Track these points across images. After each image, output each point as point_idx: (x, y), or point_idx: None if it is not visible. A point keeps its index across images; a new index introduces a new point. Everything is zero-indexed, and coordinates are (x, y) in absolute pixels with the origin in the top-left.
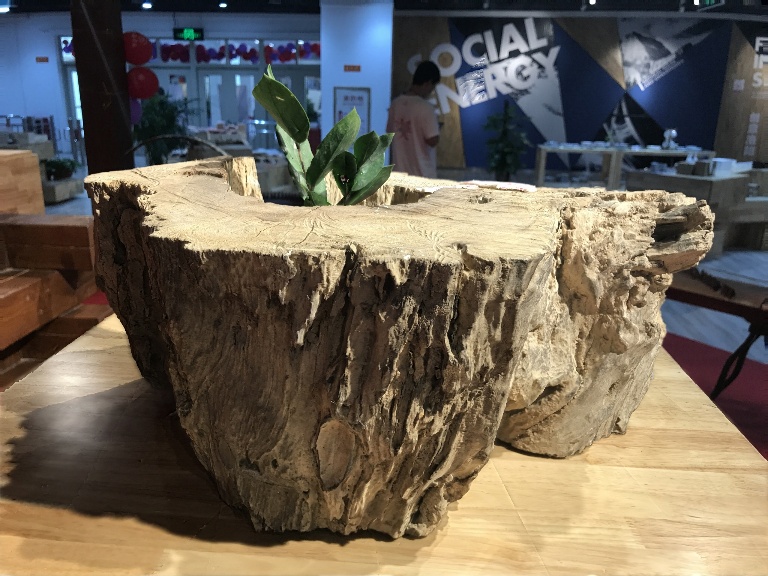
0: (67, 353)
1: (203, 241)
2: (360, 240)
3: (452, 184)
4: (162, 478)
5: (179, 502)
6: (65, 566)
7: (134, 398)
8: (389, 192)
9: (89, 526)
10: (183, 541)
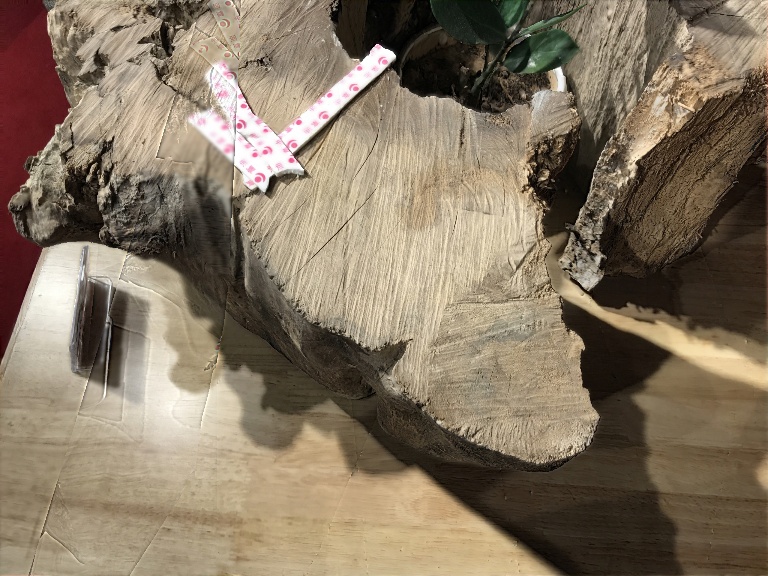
0: None
1: None
2: None
3: (309, 225)
4: None
5: None
6: None
7: None
8: None
9: None
10: None
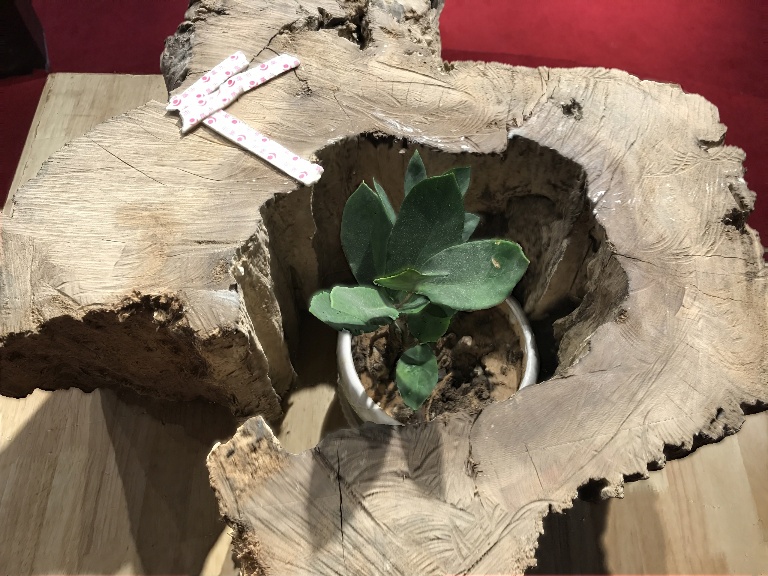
0: None
1: None
2: (712, 214)
3: (134, 143)
4: (539, 538)
5: None
6: (671, 567)
7: None
8: (263, 223)
9: (623, 574)
10: None
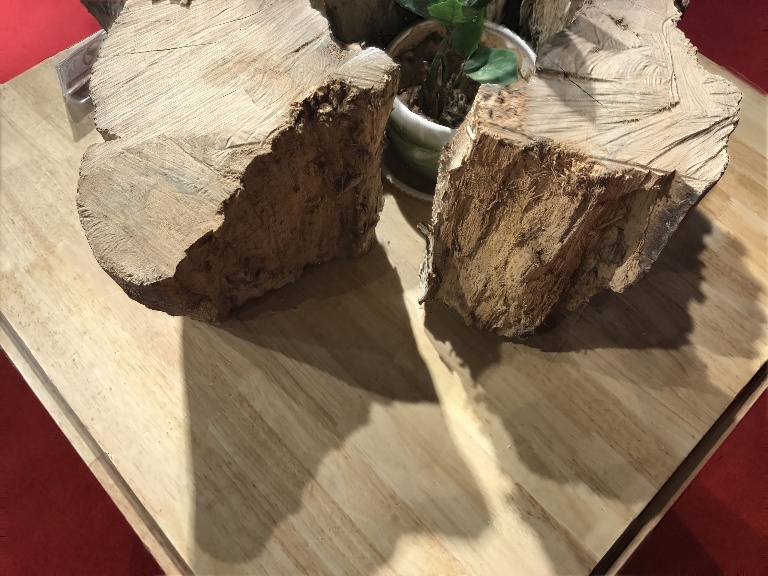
0: (627, 502)
1: None
2: None
3: (153, 35)
4: None
5: None
6: None
7: (580, 311)
8: None
9: None
10: None
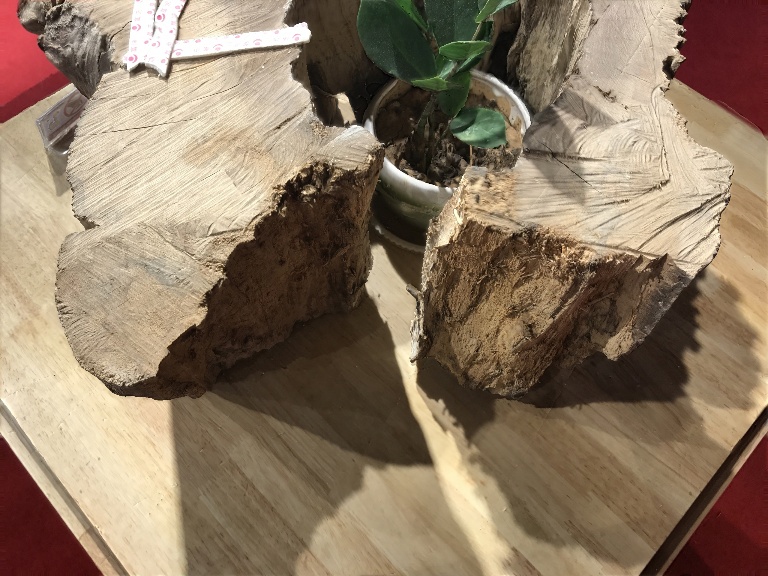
0: (625, 565)
1: None
2: None
3: (131, 111)
4: None
5: None
6: None
7: None
8: None
9: None
10: None
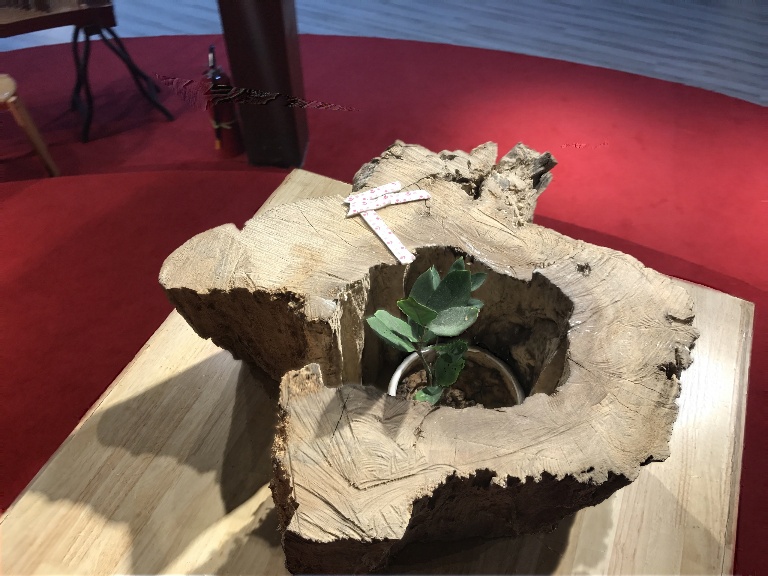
0: None
1: (649, 448)
2: (653, 361)
3: (319, 214)
4: (486, 575)
5: (520, 564)
6: None
7: None
8: None
9: None
10: (565, 563)
